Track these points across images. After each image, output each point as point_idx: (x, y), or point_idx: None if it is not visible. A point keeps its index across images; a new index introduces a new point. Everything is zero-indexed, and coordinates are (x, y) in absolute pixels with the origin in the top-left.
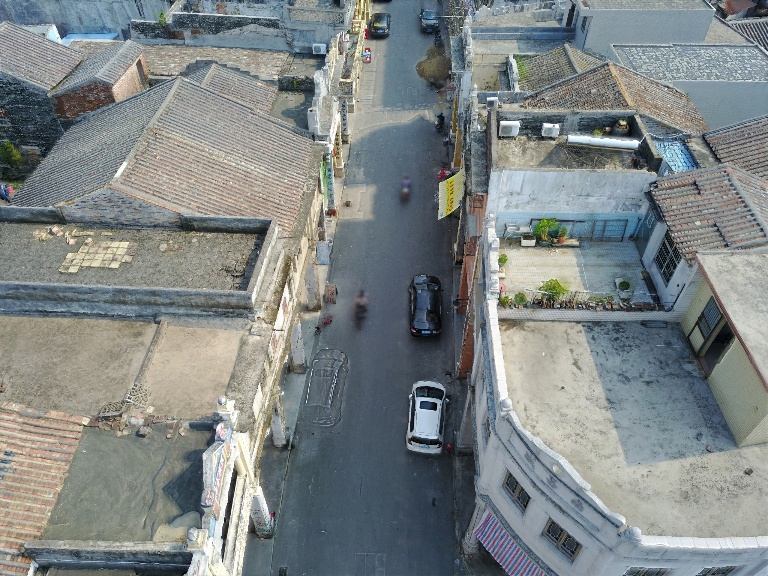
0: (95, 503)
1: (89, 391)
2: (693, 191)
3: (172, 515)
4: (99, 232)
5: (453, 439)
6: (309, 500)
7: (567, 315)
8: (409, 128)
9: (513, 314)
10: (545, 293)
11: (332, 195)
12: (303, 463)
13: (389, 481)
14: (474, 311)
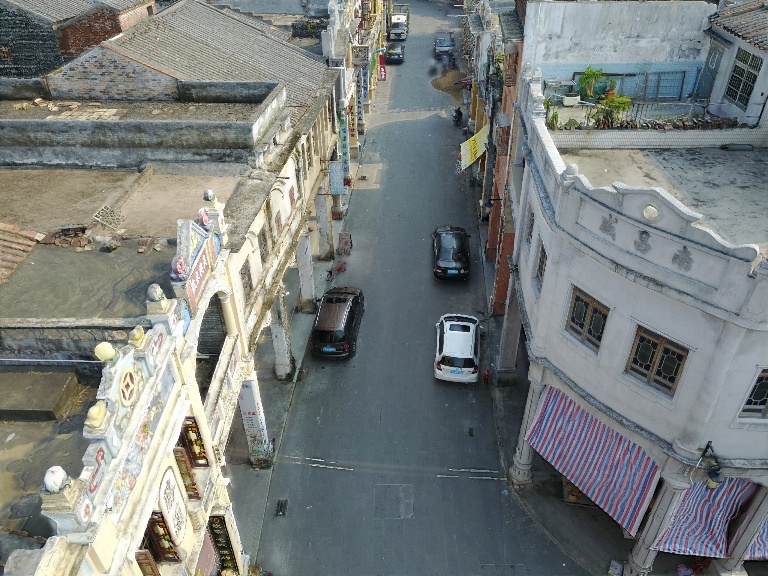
0: (35, 304)
1: (50, 219)
2: (763, 11)
3: (134, 314)
4: (87, 104)
5: (490, 371)
6: (317, 431)
7: (629, 139)
8: (426, 123)
9: (563, 140)
10: (601, 111)
11: (347, 161)
12: (310, 395)
13: (415, 411)
14: (511, 197)
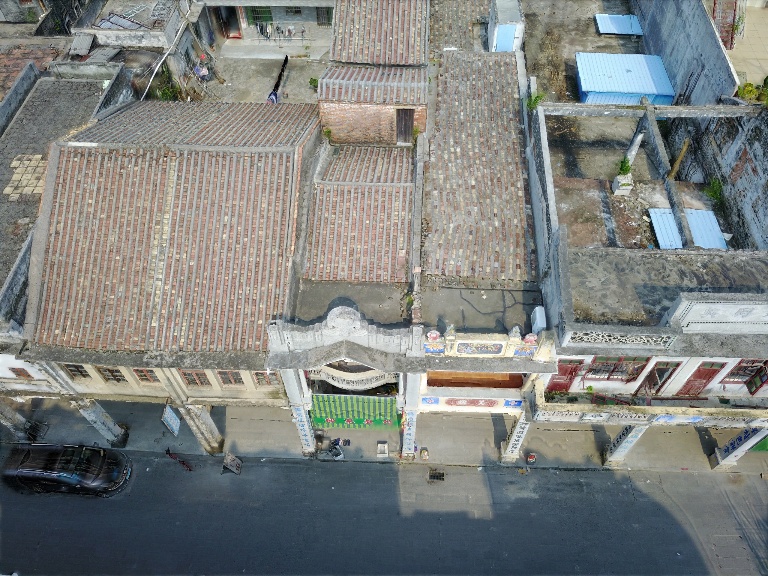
0: None
1: None
2: None
3: None
4: None
5: None
6: None
7: None
8: None
9: None
10: None
11: None
12: None
13: None
14: None
